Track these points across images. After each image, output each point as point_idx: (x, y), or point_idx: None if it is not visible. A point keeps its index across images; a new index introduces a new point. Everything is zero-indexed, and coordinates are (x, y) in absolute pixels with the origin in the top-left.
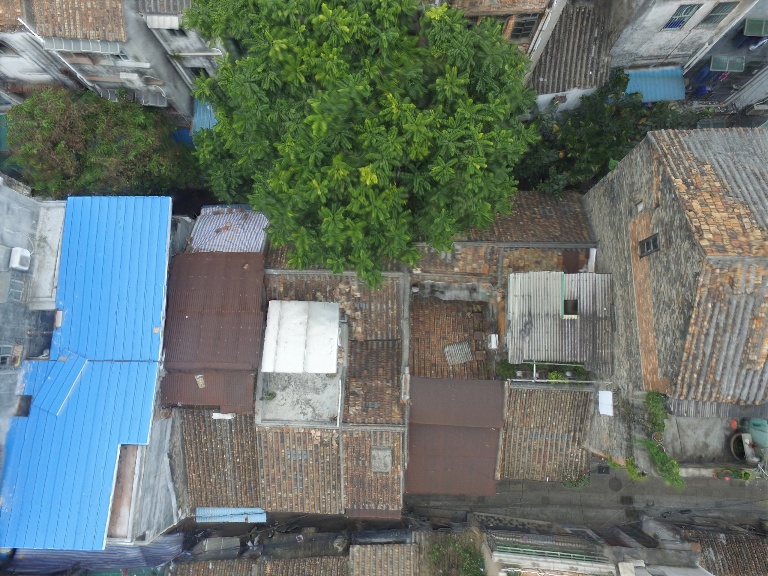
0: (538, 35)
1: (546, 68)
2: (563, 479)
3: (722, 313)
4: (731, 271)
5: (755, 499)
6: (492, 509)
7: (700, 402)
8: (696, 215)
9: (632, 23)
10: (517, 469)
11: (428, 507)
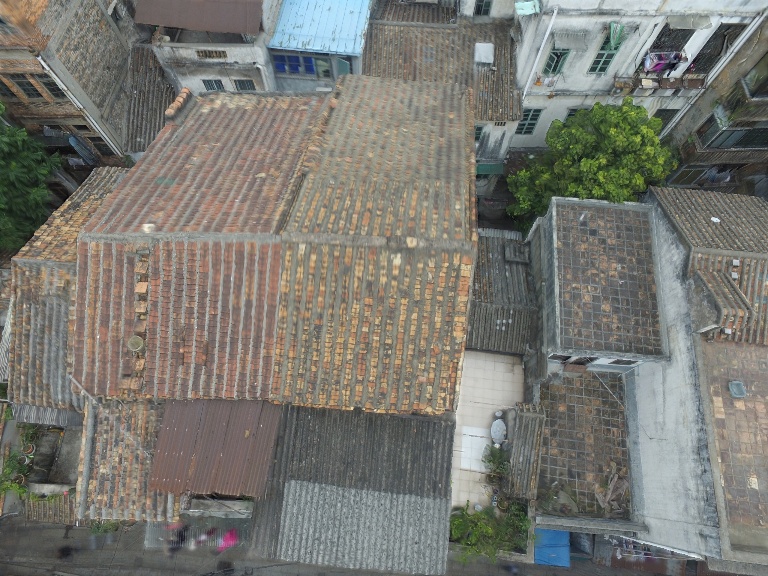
0: (68, 94)
1: (142, 130)
2: (91, 524)
3: (38, 314)
4: (40, 274)
5: (360, 572)
6: (78, 569)
7: (40, 408)
8: (47, 228)
9: (177, 93)
10: (45, 510)
11: (9, 563)
